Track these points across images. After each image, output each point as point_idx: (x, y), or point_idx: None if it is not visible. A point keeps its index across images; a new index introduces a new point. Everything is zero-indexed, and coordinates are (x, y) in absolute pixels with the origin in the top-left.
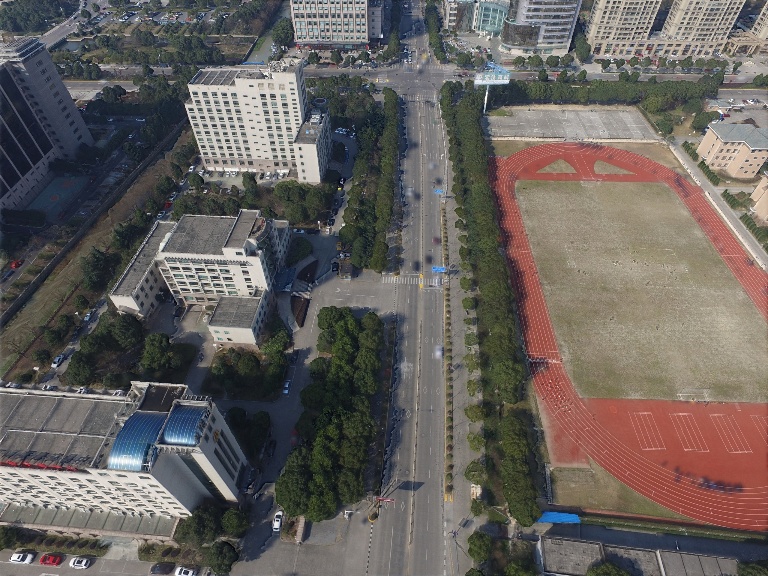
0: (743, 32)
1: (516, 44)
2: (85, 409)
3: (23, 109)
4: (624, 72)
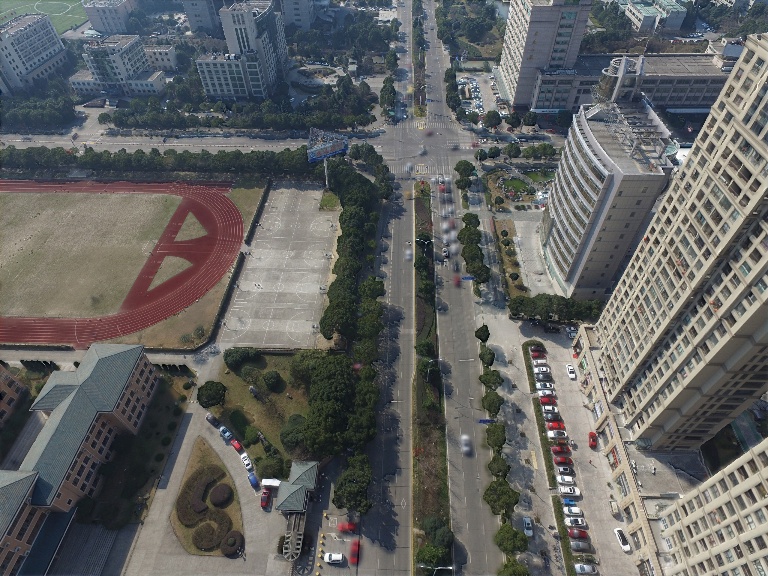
0: None
1: None
2: None
3: None
4: None
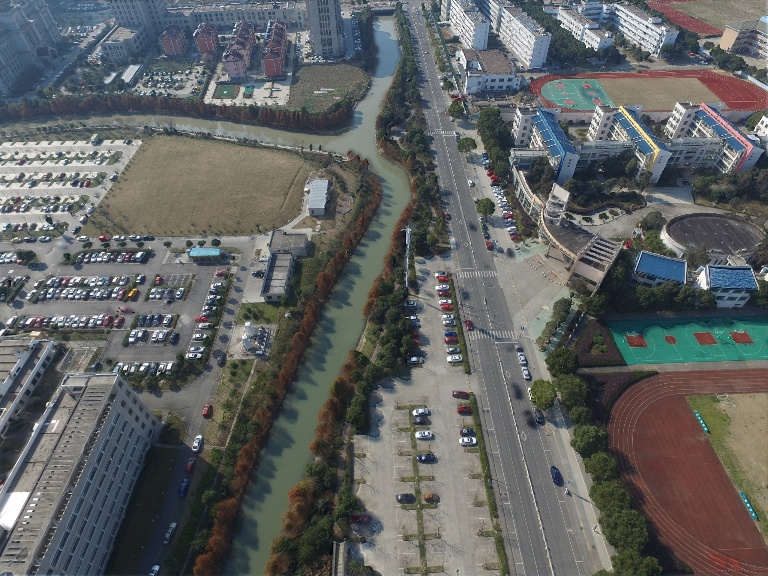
0: None
1: None
2: None
3: None
4: None
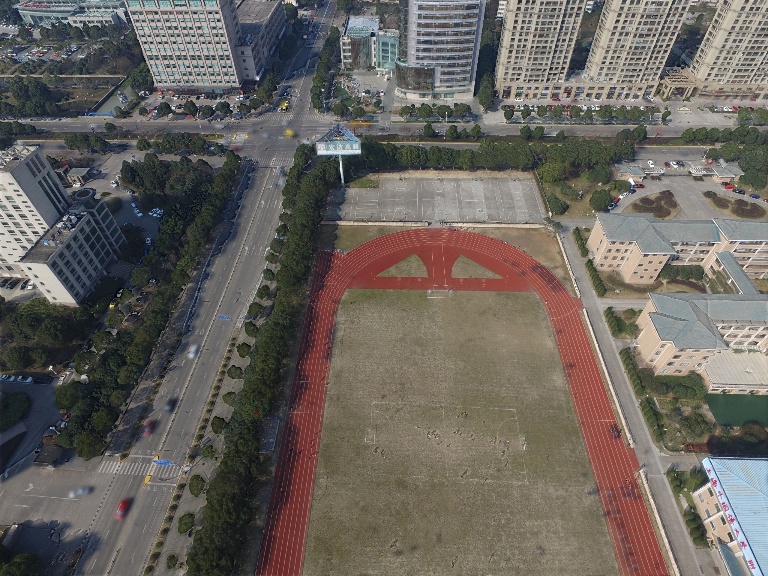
0: (680, 70)
1: (410, 88)
2: None
3: None
4: (525, 127)
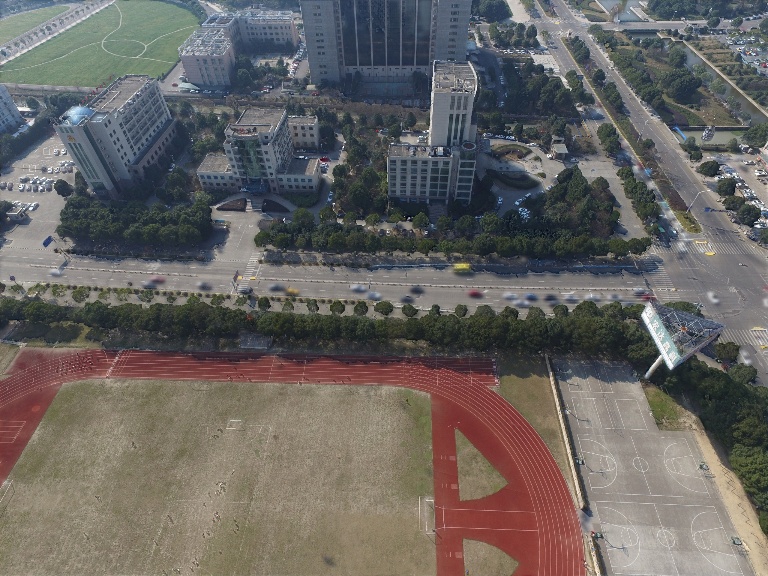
0: None
1: None
2: (119, 105)
3: (425, 29)
4: None
